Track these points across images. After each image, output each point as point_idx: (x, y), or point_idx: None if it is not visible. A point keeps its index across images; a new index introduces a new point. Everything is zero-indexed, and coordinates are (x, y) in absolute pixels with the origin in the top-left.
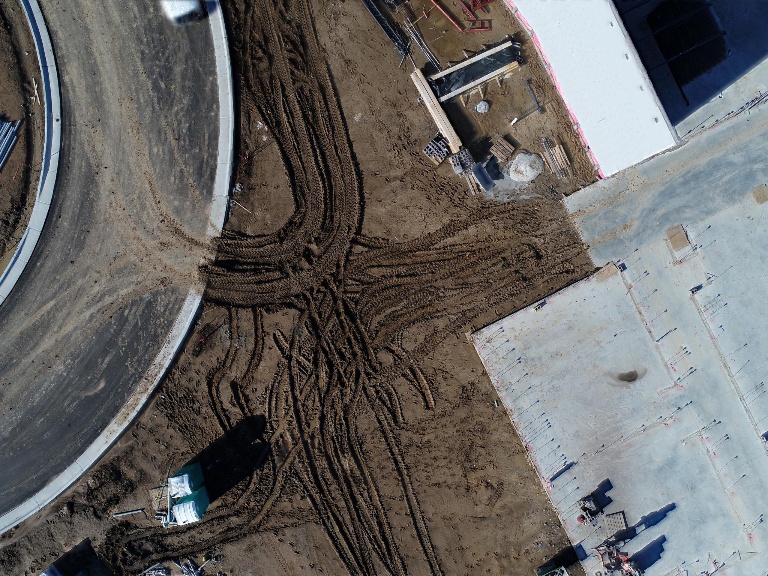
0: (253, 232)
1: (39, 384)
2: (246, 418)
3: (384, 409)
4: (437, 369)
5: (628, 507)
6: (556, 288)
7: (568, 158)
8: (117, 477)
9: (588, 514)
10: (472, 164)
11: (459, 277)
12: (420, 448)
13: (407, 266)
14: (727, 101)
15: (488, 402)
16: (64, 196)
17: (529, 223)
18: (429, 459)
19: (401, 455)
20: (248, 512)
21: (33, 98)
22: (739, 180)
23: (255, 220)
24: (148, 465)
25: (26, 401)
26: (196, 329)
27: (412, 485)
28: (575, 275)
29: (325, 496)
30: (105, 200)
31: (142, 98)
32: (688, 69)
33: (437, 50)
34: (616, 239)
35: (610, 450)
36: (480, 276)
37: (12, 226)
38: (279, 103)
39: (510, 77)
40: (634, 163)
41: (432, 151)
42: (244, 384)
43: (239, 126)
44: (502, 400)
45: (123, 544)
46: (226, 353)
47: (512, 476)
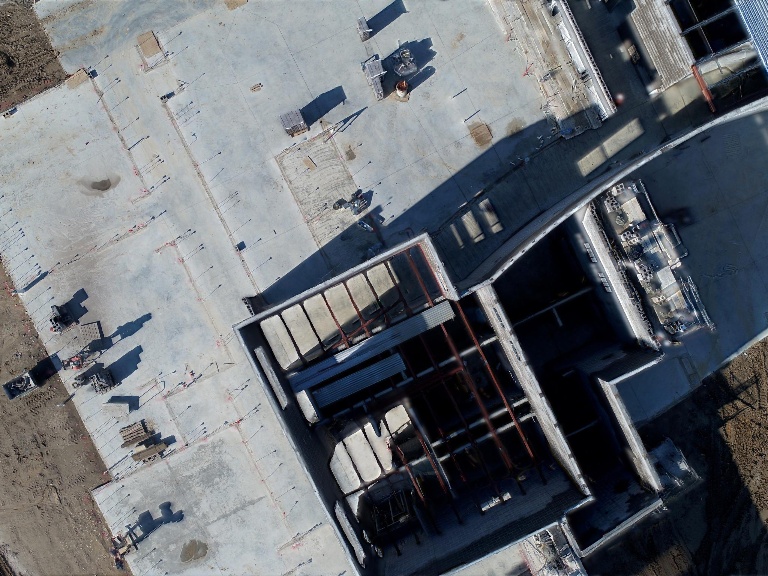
0: None
1: None
2: None
3: None
4: None
5: (104, 317)
6: (30, 96)
7: None
8: None
9: (52, 320)
10: None
11: None
12: None
13: None
14: None
15: None
16: None
17: (1, 30)
18: None
19: None
20: None
21: None
22: None
23: None
24: None
25: None
26: None
27: None
28: (48, 83)
29: None
30: None
31: None
32: None
33: None
34: (86, 45)
35: (85, 260)
36: None
37: None
38: None
39: None
40: None
41: None
42: None
43: None
44: None
45: None
46: None
47: None
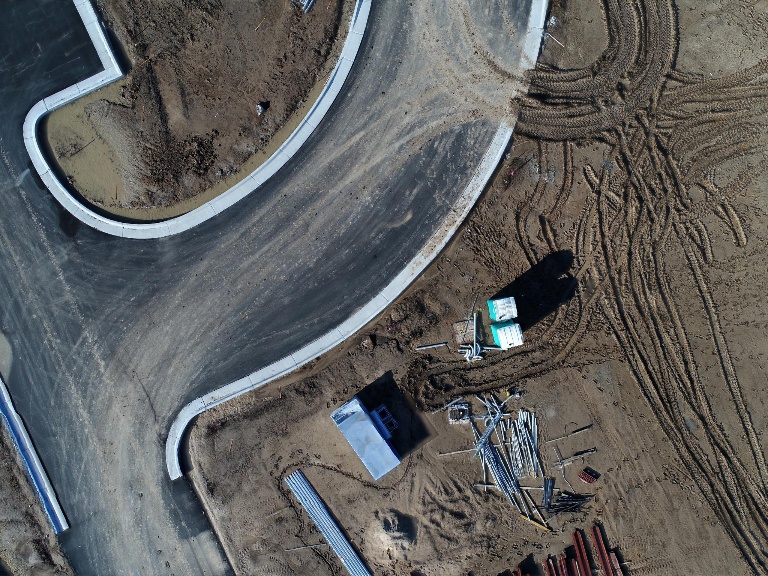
0: (565, 66)
1: (346, 215)
2: (553, 253)
3: (694, 246)
4: (749, 206)
5: None
6: None
7: None
8: (422, 310)
9: None
10: None
11: None
12: (729, 286)
13: (721, 102)
14: None
15: None
16: (377, 27)
17: None
18: (738, 298)
19: (710, 293)
20: (552, 348)
21: None
22: None
23: (568, 54)
24: (453, 299)
25: (332, 232)
26: (504, 163)
27: (720, 324)
28: None
29: (631, 333)
30: (418, 31)
31: None
32: None
33: None
34: None
35: None
36: None
37: (324, 56)
38: None
39: None
40: None
41: None
42: (552, 219)
43: None
44: None
45: (425, 378)
46: (535, 187)
47: None
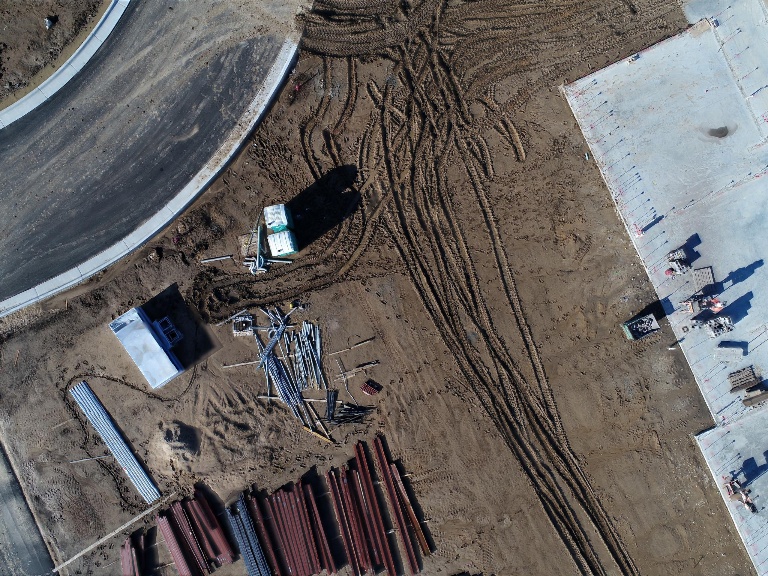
0: None
1: (133, 128)
2: (337, 167)
3: (475, 161)
4: (529, 122)
5: (716, 263)
6: (649, 44)
7: None
8: (207, 222)
9: (678, 263)
10: None
11: (553, 31)
12: (509, 201)
13: (502, 19)
14: None
15: (579, 155)
16: None
17: None
18: (518, 212)
19: (490, 207)
20: (336, 261)
21: None
22: None
23: None
24: (238, 212)
25: (119, 145)
26: (290, 78)
27: (500, 238)
28: (668, 31)
29: (413, 247)
30: None
31: None
32: None
33: None
34: None
35: (699, 205)
36: (574, 30)
37: None
38: None
39: None
40: None
41: None
42: (336, 133)
43: None
44: (593, 152)
45: (210, 290)
46: (320, 102)
47: (601, 230)
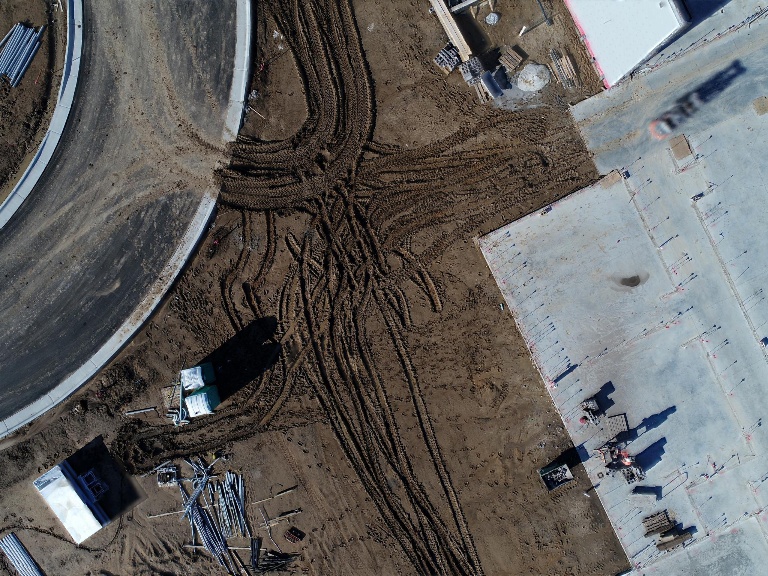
0: (267, 138)
1: (56, 283)
2: (258, 319)
3: (392, 312)
4: (445, 273)
5: (630, 410)
6: (561, 195)
7: (574, 69)
8: (130, 375)
9: (591, 414)
10: (481, 72)
11: (467, 183)
12: (427, 350)
13: (417, 172)
14: (728, 15)
15: (494, 305)
16: (84, 100)
17: (536, 131)
18: (436, 361)
19: (408, 357)
20: (258, 411)
21: (56, 5)
22: (740, 92)
23: (269, 126)
24: (161, 364)
25: (43, 300)
26: (210, 232)
27: (419, 387)
28: (580, 182)
29: (334, 397)
30: (124, 105)
31: (162, 6)
32: None
33: None
34: (620, 148)
35: (613, 353)
36: (488, 182)
37: (33, 129)
38: (295, 13)
39: None
40: (639, 61)
41: (442, 60)
42: (256, 286)
43: (255, 34)
44: (508, 303)
45: (135, 442)
46: (239, 255)
47: (517, 378)
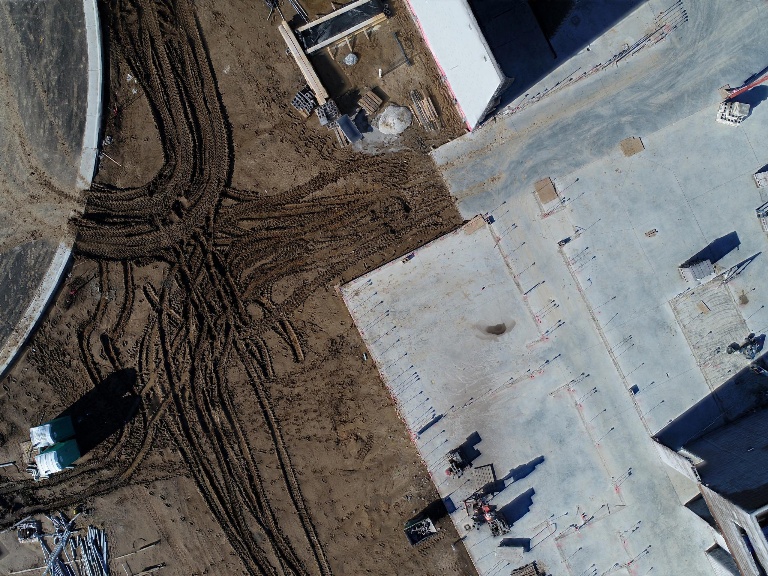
0: (123, 185)
1: None
2: (117, 371)
3: (254, 362)
4: (307, 322)
5: (497, 460)
6: (425, 241)
7: (436, 111)
8: None
9: (454, 466)
10: (338, 116)
11: (328, 230)
12: (290, 401)
13: (276, 219)
14: (595, 54)
15: (357, 355)
16: None
17: (398, 176)
18: (299, 412)
19: (271, 408)
20: (119, 465)
21: None
22: (607, 133)
23: (125, 173)
24: (19, 418)
25: None
26: (67, 282)
27: (282, 438)
28: (444, 228)
29: (196, 449)
30: None
31: (11, 50)
32: (551, 20)
33: (305, 2)
34: (484, 192)
35: (479, 403)
36: (349, 229)
37: None
38: (148, 56)
39: (378, 29)
40: (483, 109)
41: (299, 103)
42: (115, 337)
43: (108, 79)
44: (370, 353)
45: None
46: (96, 306)
47: (382, 429)
